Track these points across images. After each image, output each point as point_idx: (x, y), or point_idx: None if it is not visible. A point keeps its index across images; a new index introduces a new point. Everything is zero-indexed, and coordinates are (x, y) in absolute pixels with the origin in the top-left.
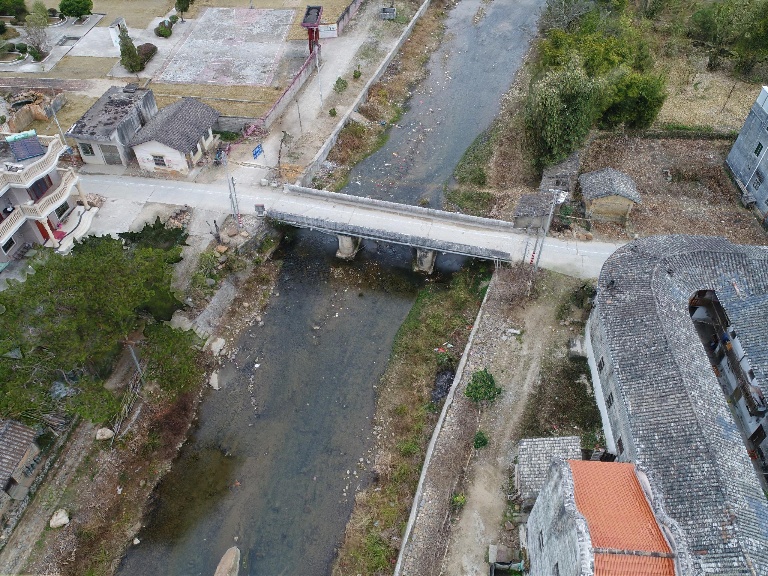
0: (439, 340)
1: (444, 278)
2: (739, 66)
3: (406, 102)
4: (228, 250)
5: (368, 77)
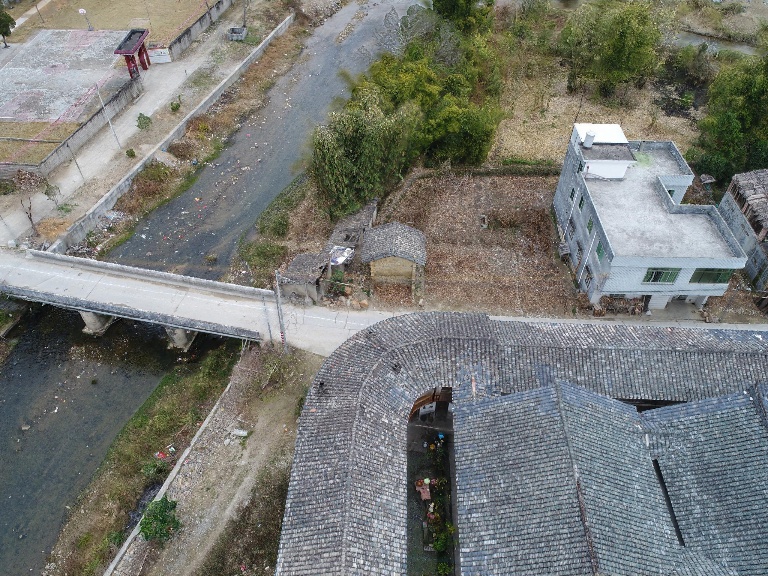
0: (164, 441)
1: (200, 356)
2: (599, 88)
3: (231, 136)
4: None
5: (190, 109)
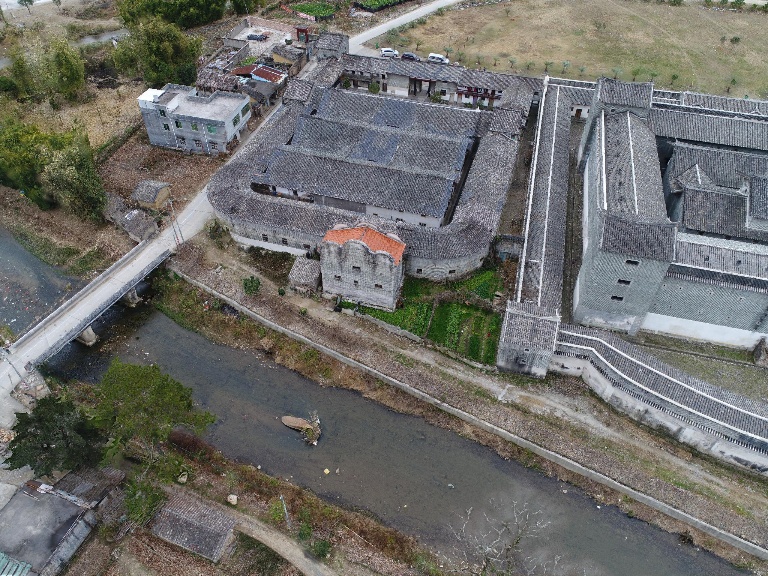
0: None
1: (151, 294)
2: (68, 98)
3: None
4: None
5: None
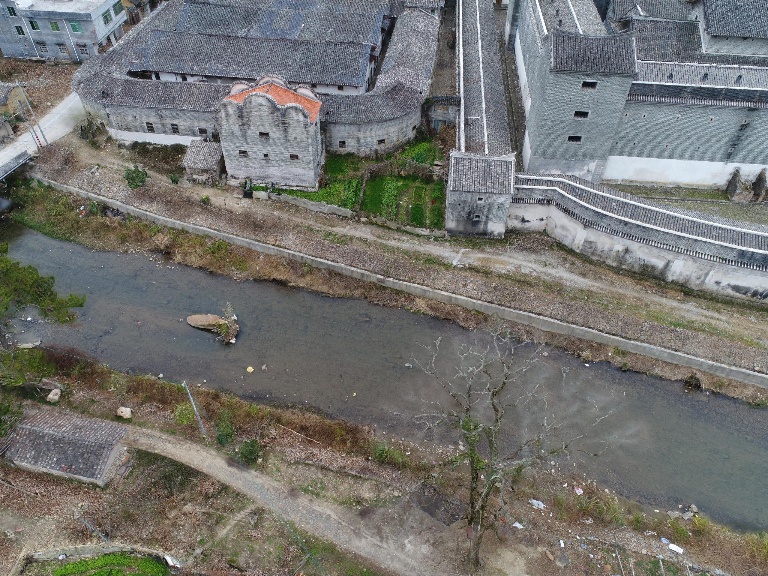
0: None
1: (8, 208)
2: None
3: None
4: None
5: None
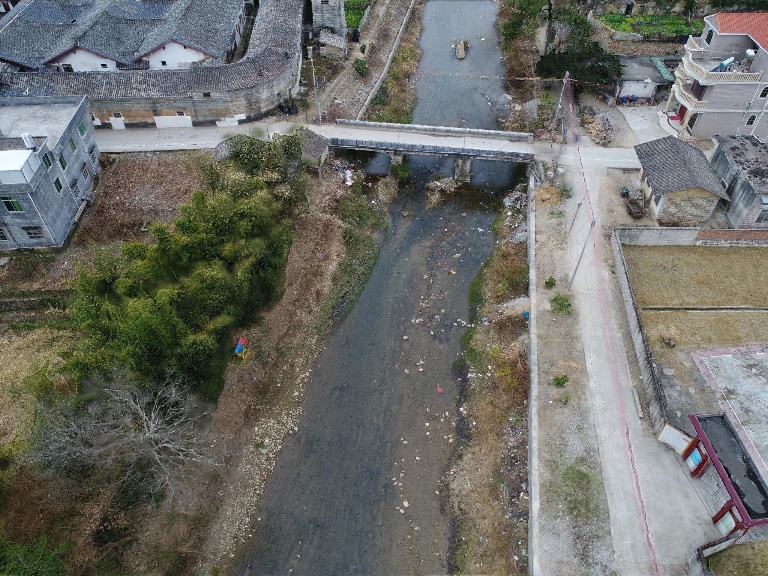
0: None
1: None
2: None
3: (464, 384)
4: None
5: None
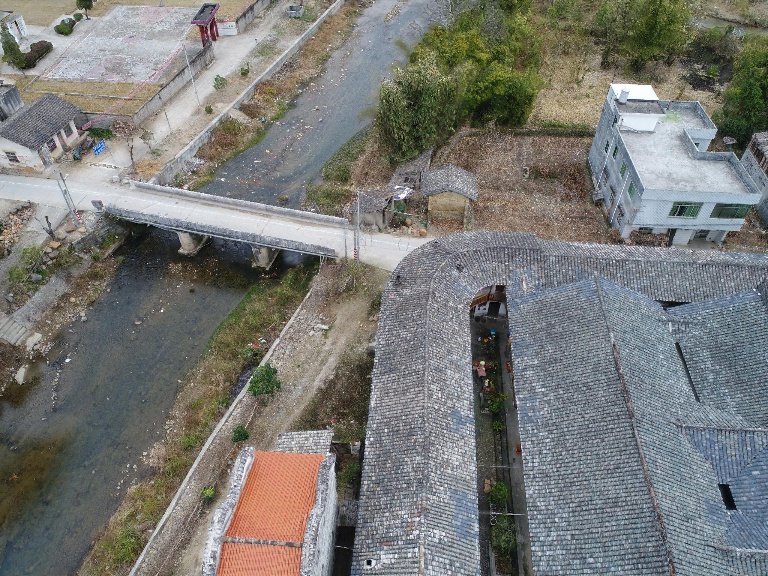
0: (255, 335)
1: (280, 274)
2: (631, 64)
3: (294, 99)
4: (62, 246)
5: (257, 75)
